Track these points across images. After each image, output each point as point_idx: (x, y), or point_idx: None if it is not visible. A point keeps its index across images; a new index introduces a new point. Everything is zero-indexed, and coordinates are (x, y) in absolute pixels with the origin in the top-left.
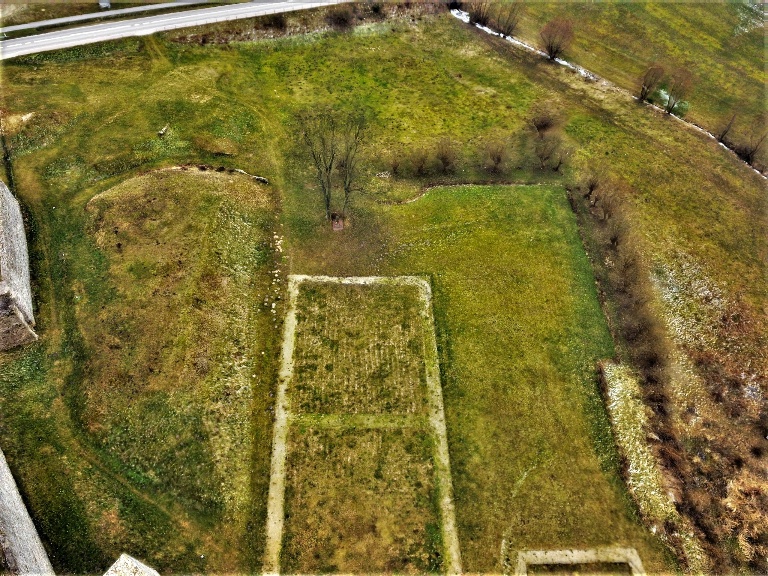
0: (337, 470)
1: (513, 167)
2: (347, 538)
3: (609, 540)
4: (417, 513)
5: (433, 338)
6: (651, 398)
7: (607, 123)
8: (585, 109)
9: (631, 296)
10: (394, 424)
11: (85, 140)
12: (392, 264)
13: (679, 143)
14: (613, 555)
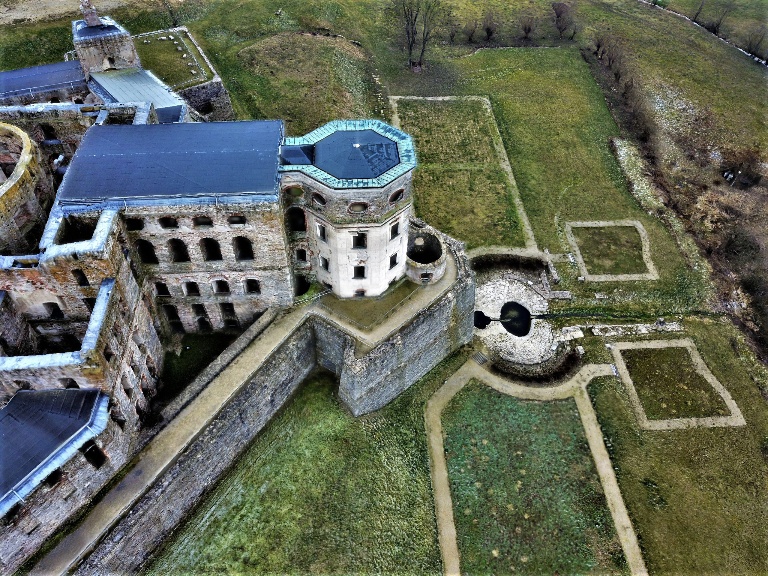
0: (444, 188)
1: (539, 38)
2: (457, 216)
3: (622, 217)
4: (499, 205)
5: (496, 126)
6: (646, 156)
7: (608, 11)
8: (590, 3)
9: (630, 107)
10: (477, 167)
11: (225, 16)
12: (460, 90)
13: (663, 22)
14: (625, 223)
